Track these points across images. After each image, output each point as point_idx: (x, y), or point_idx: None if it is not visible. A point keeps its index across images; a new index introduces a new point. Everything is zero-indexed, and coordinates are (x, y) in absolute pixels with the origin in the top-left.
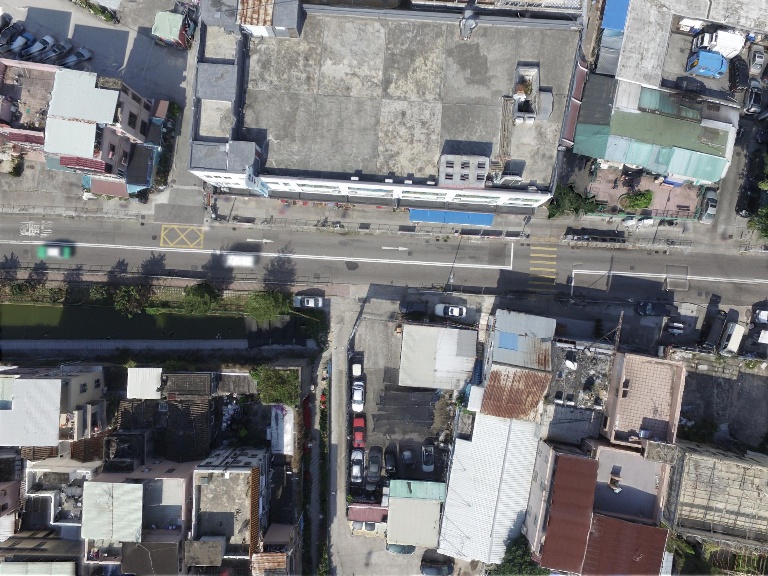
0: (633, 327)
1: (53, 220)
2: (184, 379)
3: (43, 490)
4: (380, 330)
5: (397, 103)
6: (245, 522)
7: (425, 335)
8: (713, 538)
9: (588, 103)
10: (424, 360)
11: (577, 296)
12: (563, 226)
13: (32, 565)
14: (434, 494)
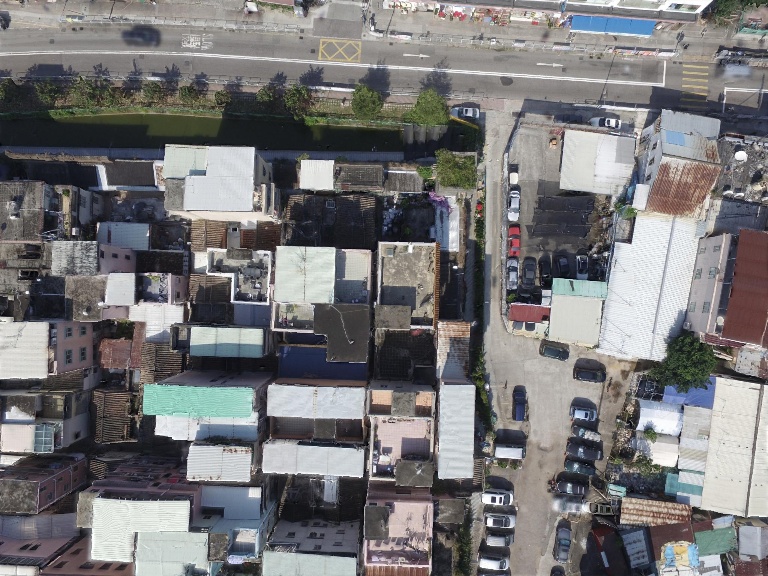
0: None
1: (214, 33)
2: (357, 170)
3: (221, 272)
4: (534, 144)
5: None
6: (427, 296)
7: (585, 141)
8: None
9: None
10: (584, 165)
11: (729, 113)
12: (715, 45)
13: (222, 330)
14: (596, 292)
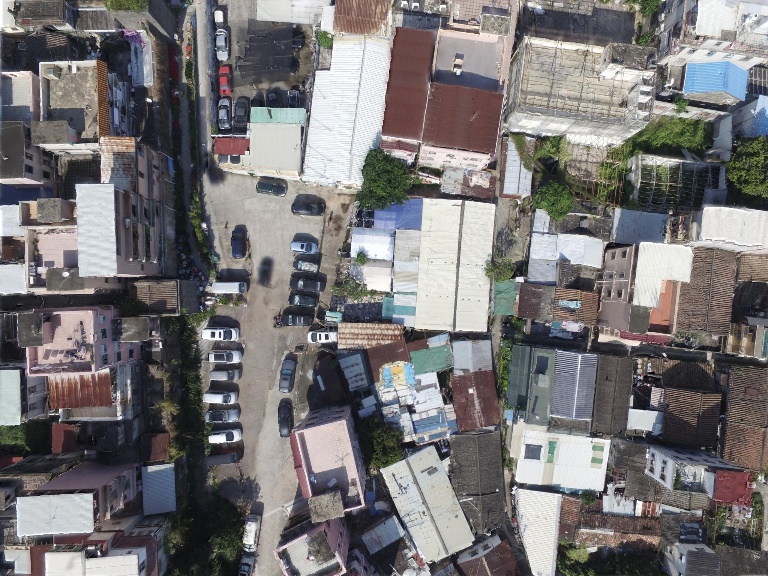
0: None
1: None
2: (37, 5)
3: None
4: None
5: None
6: (95, 116)
7: None
8: (554, 117)
9: None
10: None
11: None
12: None
13: None
14: (294, 119)
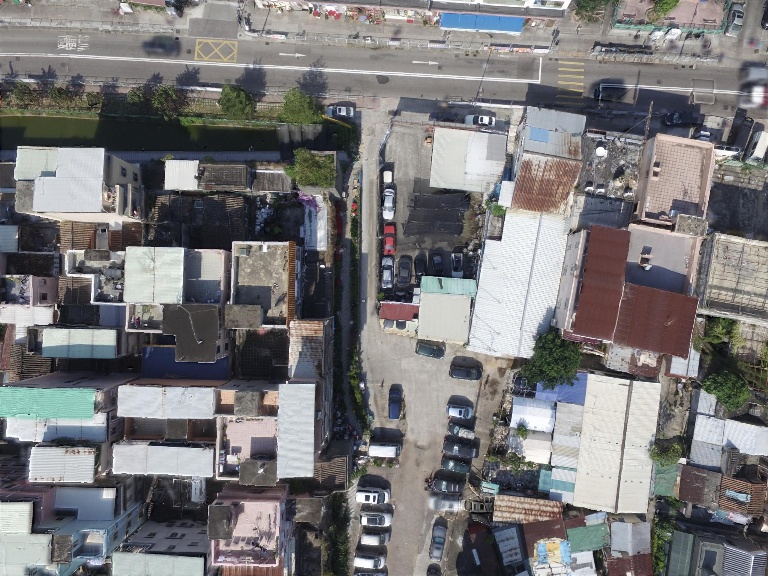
0: None
1: (90, 34)
2: (221, 170)
3: (83, 273)
4: (410, 142)
5: None
6: (282, 295)
7: (456, 138)
8: (742, 316)
9: None
10: (455, 163)
11: (604, 109)
12: (591, 41)
13: (74, 332)
14: (464, 290)
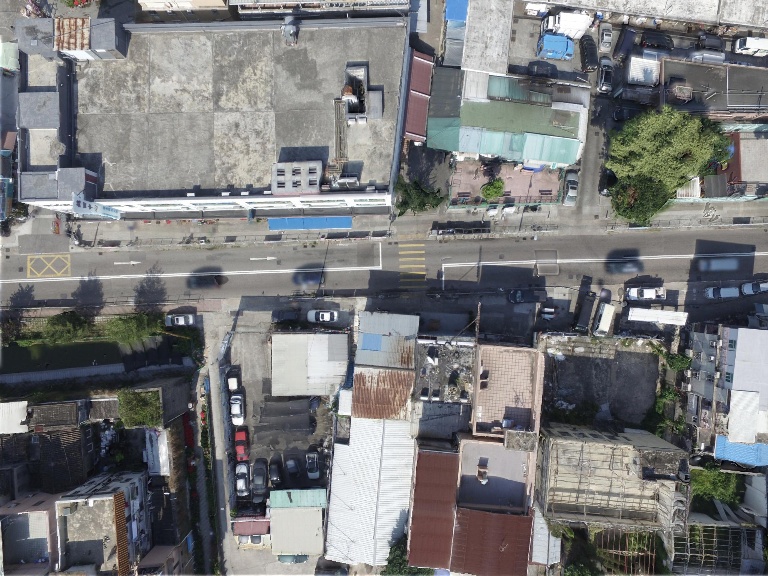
0: (507, 316)
1: None
2: (49, 410)
3: None
4: (255, 342)
5: (229, 115)
6: (114, 548)
7: (294, 343)
8: (584, 521)
9: (438, 96)
10: (296, 368)
11: (448, 290)
12: (429, 221)
13: None
14: (315, 501)
